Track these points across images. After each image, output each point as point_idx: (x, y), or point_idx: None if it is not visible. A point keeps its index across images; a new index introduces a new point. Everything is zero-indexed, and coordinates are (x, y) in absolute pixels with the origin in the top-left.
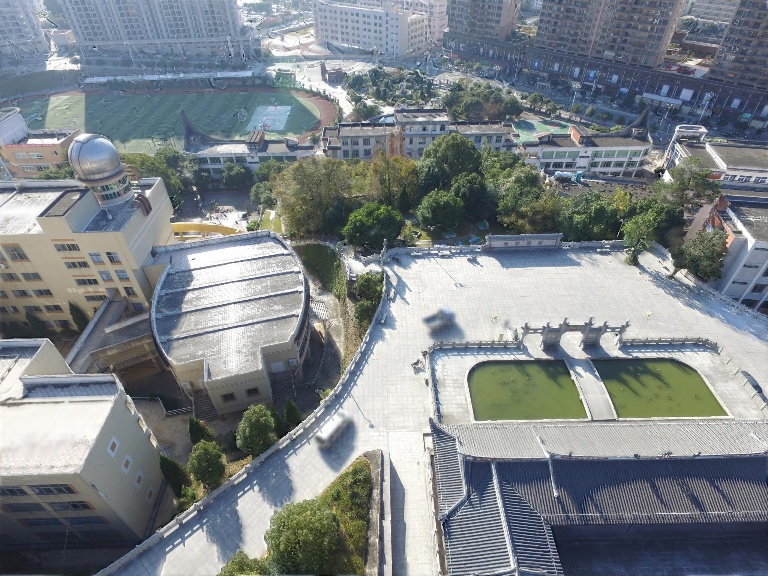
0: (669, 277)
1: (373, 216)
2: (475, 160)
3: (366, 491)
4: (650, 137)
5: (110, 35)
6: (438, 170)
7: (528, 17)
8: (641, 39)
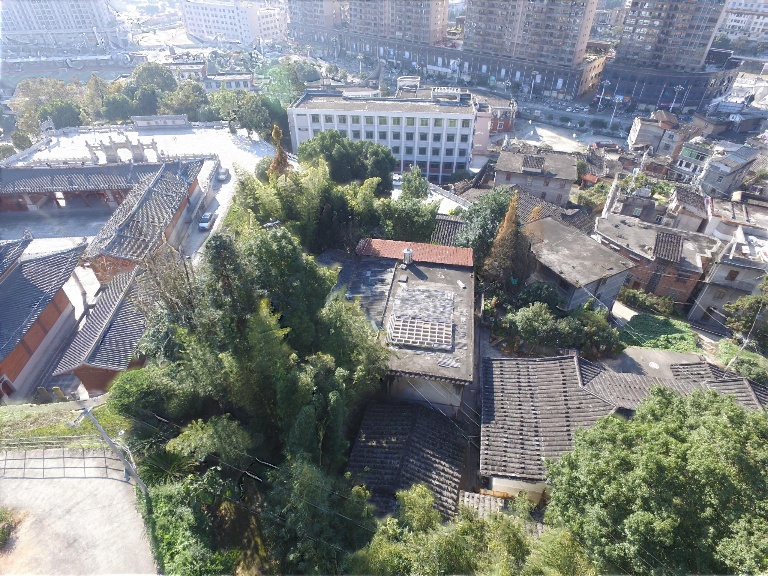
0: (246, 137)
1: (54, 106)
2: (165, 79)
3: None
4: (379, 86)
5: None
6: (138, 87)
7: (343, 7)
8: (416, 20)
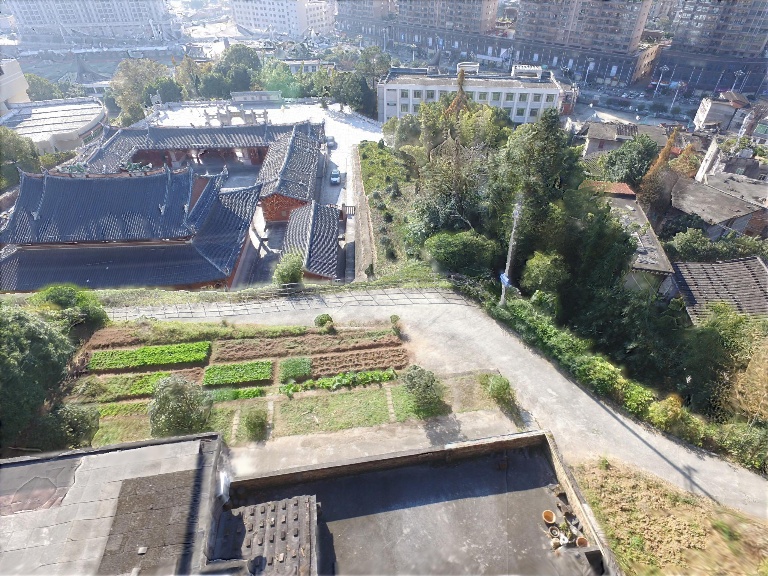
0: (339, 111)
1: (158, 83)
2: (252, 60)
3: (65, 156)
4: (439, 71)
5: (47, 19)
6: (227, 68)
7: None
8: (468, 10)
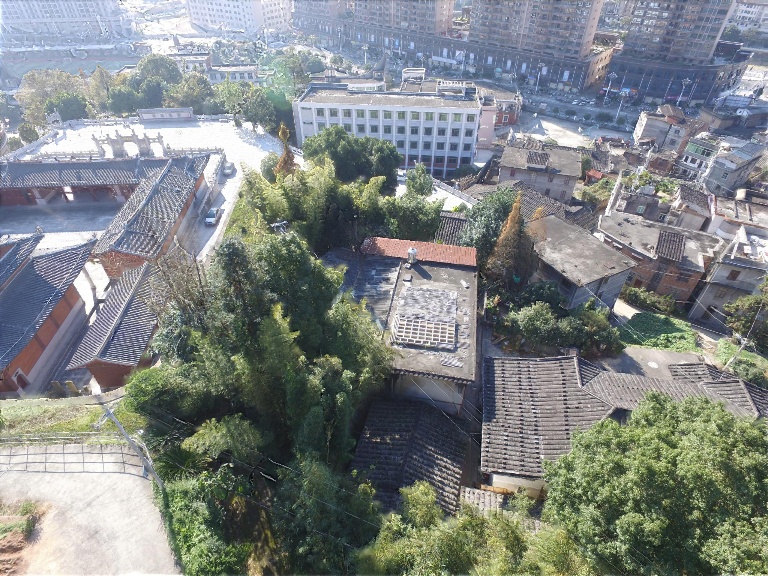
0: (252, 131)
1: (60, 99)
2: (170, 71)
3: None
4: (384, 77)
5: None
6: (143, 79)
7: None
8: (422, 10)
